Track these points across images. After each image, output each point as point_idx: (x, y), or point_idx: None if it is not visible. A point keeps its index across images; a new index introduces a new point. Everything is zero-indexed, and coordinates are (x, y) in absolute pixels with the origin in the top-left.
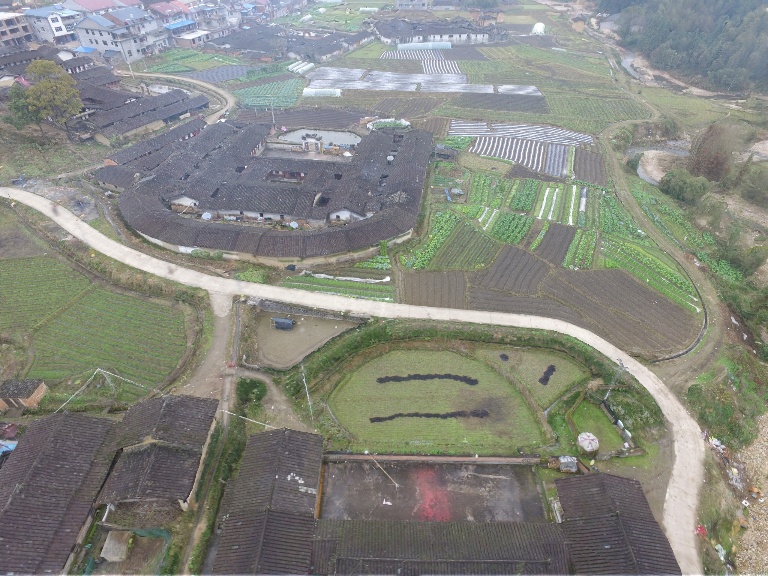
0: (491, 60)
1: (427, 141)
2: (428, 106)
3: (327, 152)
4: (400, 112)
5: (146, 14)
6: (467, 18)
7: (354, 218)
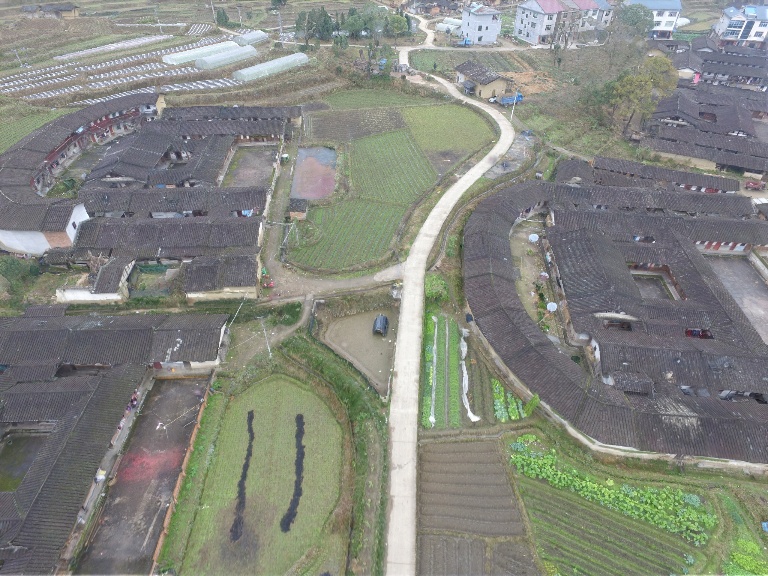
0: None
1: None
2: None
3: None
4: None
5: None
6: None
7: None
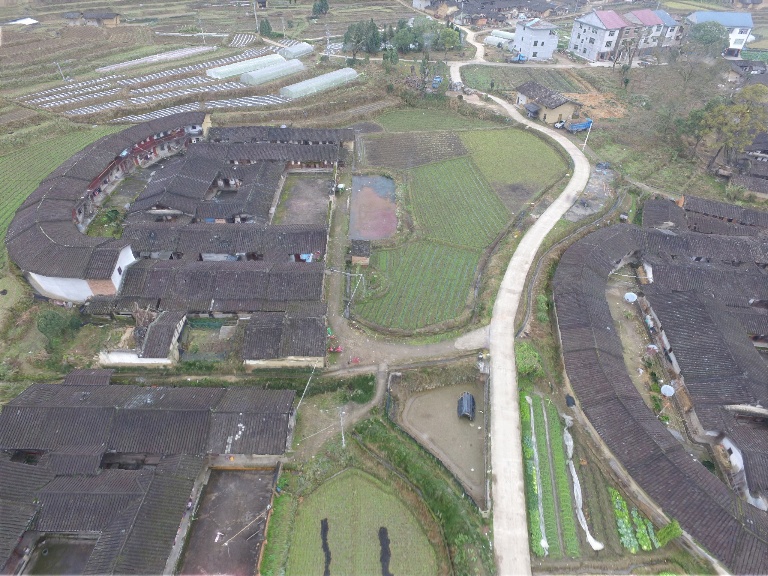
0: None
1: None
2: None
3: None
4: None
5: None
6: None
7: (743, 479)
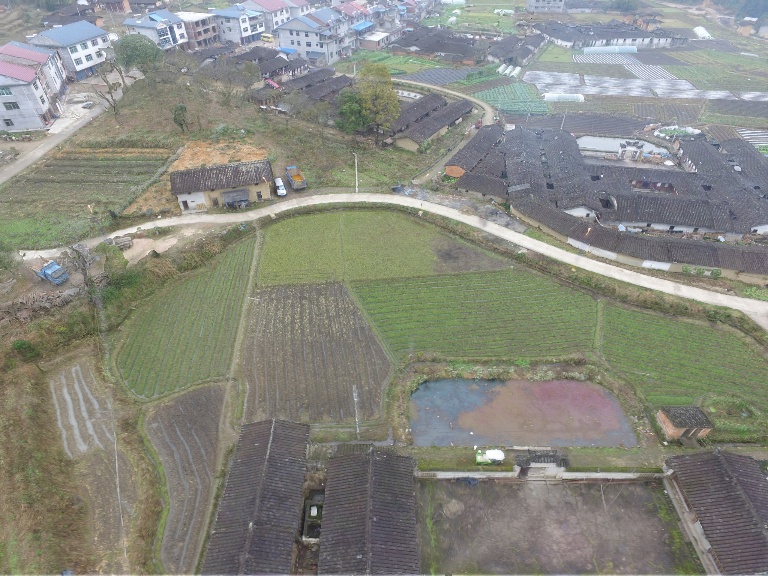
0: (693, 65)
1: (757, 151)
2: (690, 113)
3: (645, 161)
4: (668, 119)
5: (339, 15)
6: (620, 21)
7: None
